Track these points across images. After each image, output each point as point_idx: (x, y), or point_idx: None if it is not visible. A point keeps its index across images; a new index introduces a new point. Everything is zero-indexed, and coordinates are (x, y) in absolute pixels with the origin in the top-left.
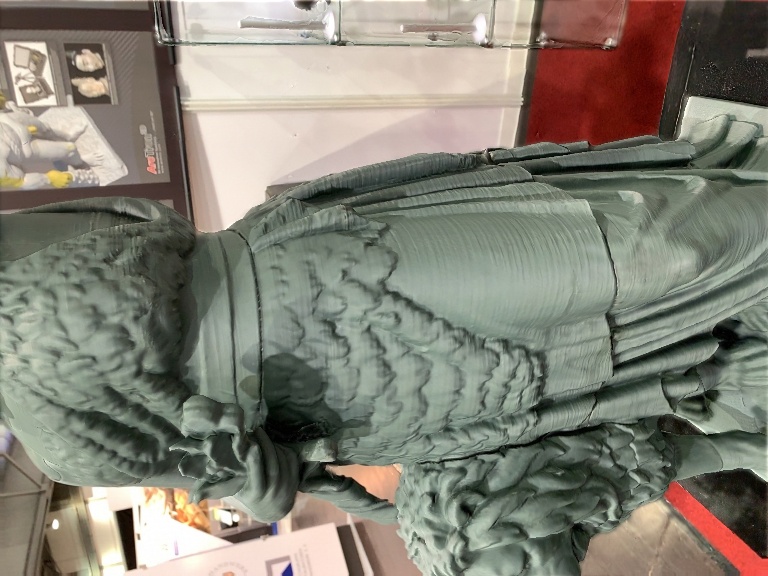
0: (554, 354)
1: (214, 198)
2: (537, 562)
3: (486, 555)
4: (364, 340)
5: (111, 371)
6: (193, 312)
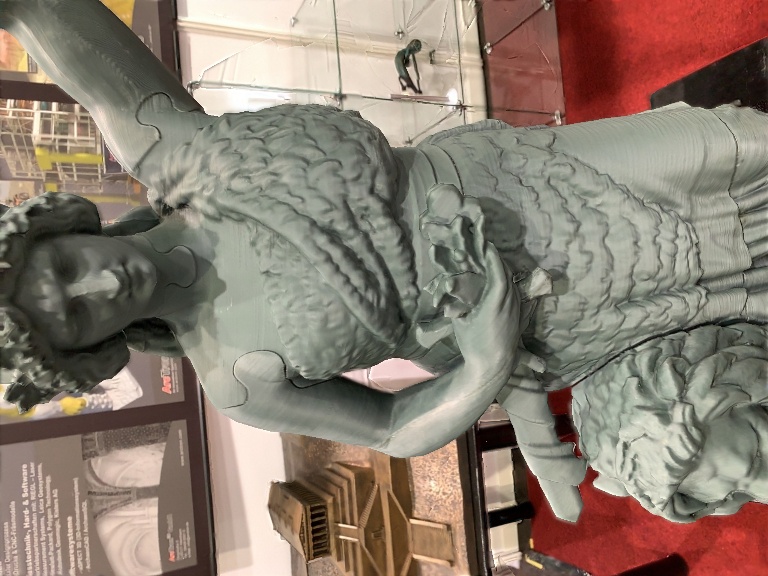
0: (700, 227)
1: (226, 418)
2: (766, 446)
3: (715, 429)
4: (548, 189)
5: (352, 181)
6: (400, 165)
